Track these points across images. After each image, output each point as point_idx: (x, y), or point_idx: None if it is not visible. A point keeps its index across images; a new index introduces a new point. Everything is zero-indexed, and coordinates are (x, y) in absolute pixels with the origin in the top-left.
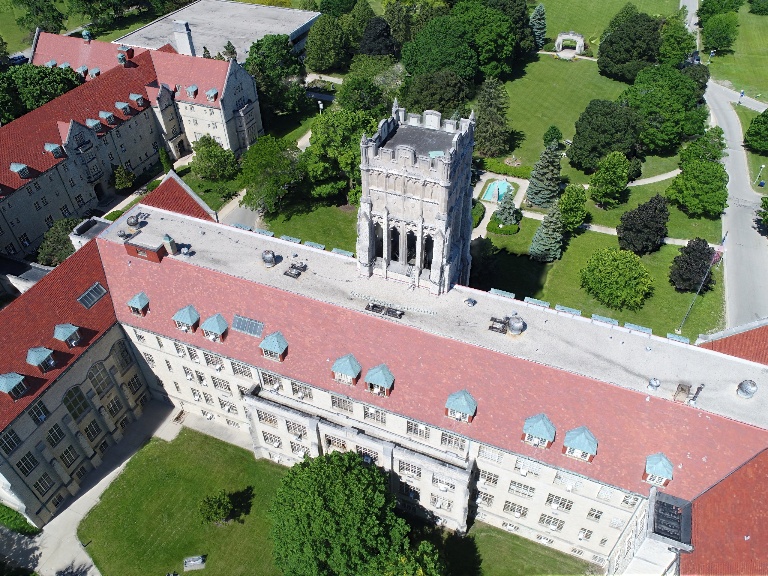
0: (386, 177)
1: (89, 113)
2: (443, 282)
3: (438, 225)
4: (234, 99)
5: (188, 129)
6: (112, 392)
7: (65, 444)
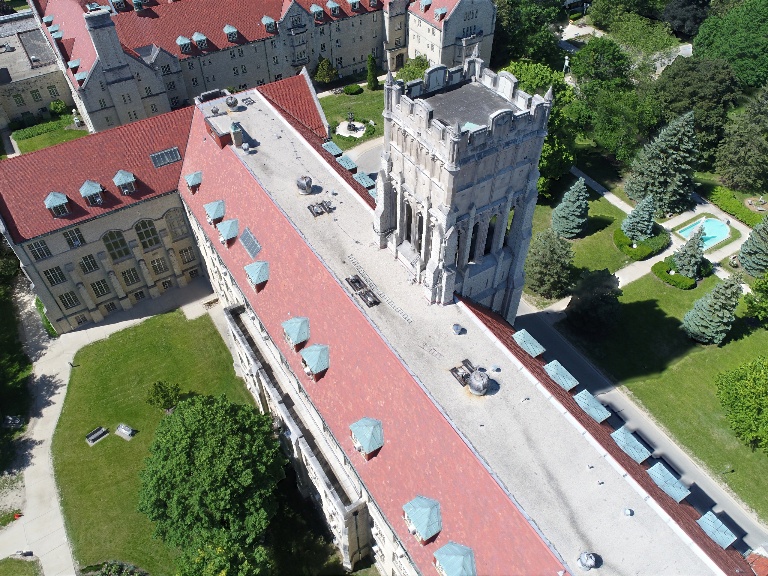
0: (404, 135)
1: None
2: (440, 290)
3: (440, 217)
4: (462, 25)
5: (411, 44)
6: (159, 252)
7: (98, 276)
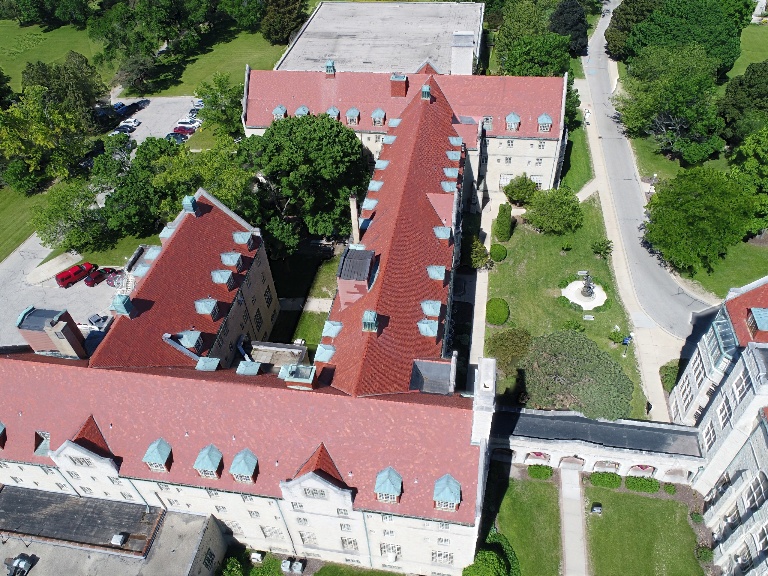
0: None
1: (438, 174)
2: None
3: None
4: None
5: (492, 171)
6: None
7: None
